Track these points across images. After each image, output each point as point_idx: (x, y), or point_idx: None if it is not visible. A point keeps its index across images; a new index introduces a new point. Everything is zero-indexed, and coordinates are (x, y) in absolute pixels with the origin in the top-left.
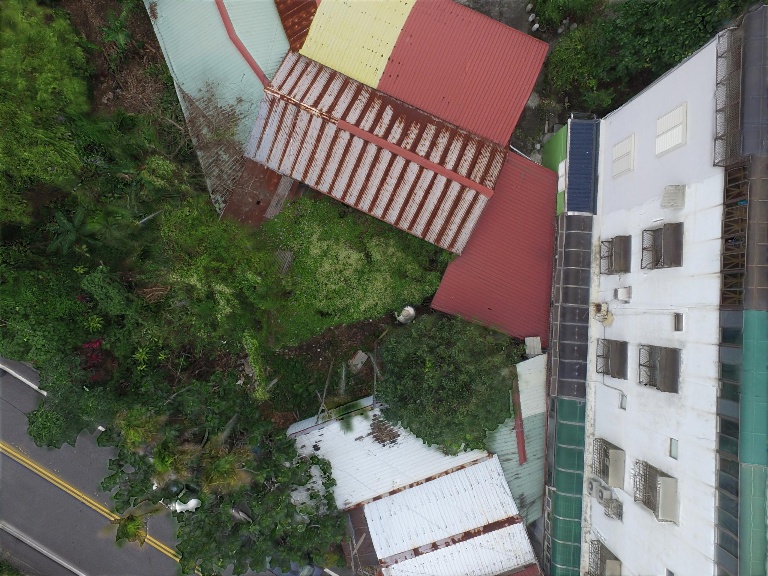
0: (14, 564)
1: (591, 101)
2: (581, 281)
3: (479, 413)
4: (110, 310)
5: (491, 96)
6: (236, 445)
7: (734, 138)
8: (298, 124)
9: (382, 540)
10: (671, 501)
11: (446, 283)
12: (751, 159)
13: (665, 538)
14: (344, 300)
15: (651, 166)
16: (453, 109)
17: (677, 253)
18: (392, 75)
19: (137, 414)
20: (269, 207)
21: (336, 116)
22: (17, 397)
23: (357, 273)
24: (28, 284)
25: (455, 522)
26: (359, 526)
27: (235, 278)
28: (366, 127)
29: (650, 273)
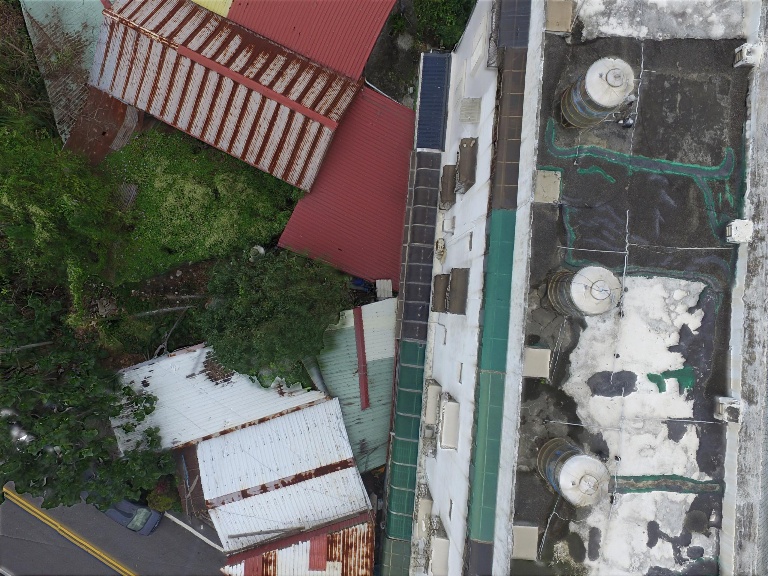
0: None
1: (446, 35)
2: (427, 220)
3: (274, 336)
4: None
5: (343, 27)
6: (31, 368)
7: (496, 31)
8: (139, 50)
9: (211, 481)
10: (454, 427)
11: (294, 221)
12: (505, 50)
13: (451, 467)
14: (189, 236)
15: (470, 88)
16: (304, 40)
17: (471, 169)
18: (242, 3)
19: None
20: (115, 138)
21: (177, 42)
22: None
23: (204, 209)
24: None
25: (287, 464)
26: (193, 468)
27: (54, 201)
28: (209, 54)
29: (463, 198)
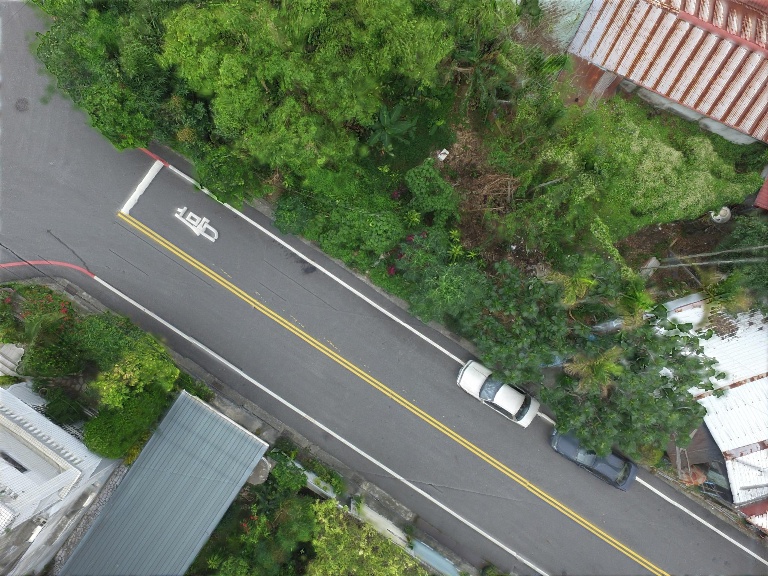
0: (324, 458)
1: None
2: None
3: None
4: (426, 206)
5: None
6: None
7: None
8: (634, 16)
9: (722, 434)
10: None
11: None
12: None
13: None
14: (664, 198)
15: None
16: None
17: None
18: None
19: (497, 295)
20: (586, 104)
21: (675, 7)
22: (327, 293)
23: (675, 171)
24: (350, 177)
25: None
26: None
27: None
28: (704, 18)
29: None
